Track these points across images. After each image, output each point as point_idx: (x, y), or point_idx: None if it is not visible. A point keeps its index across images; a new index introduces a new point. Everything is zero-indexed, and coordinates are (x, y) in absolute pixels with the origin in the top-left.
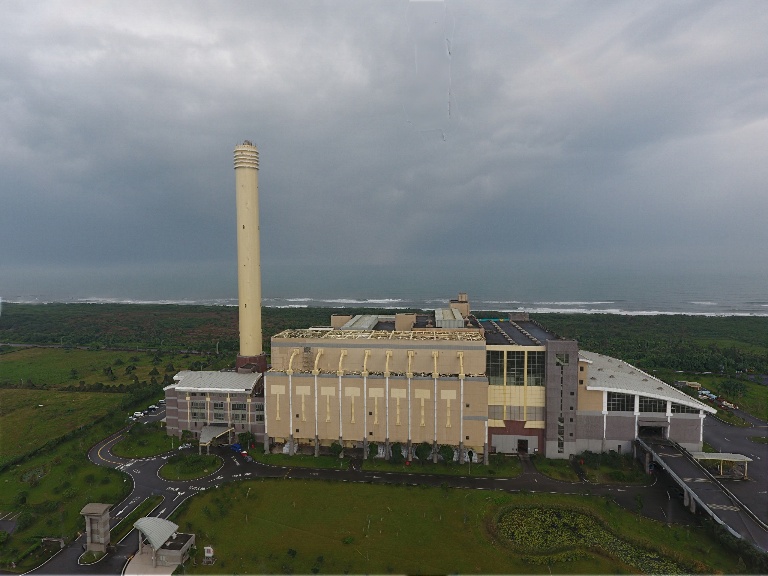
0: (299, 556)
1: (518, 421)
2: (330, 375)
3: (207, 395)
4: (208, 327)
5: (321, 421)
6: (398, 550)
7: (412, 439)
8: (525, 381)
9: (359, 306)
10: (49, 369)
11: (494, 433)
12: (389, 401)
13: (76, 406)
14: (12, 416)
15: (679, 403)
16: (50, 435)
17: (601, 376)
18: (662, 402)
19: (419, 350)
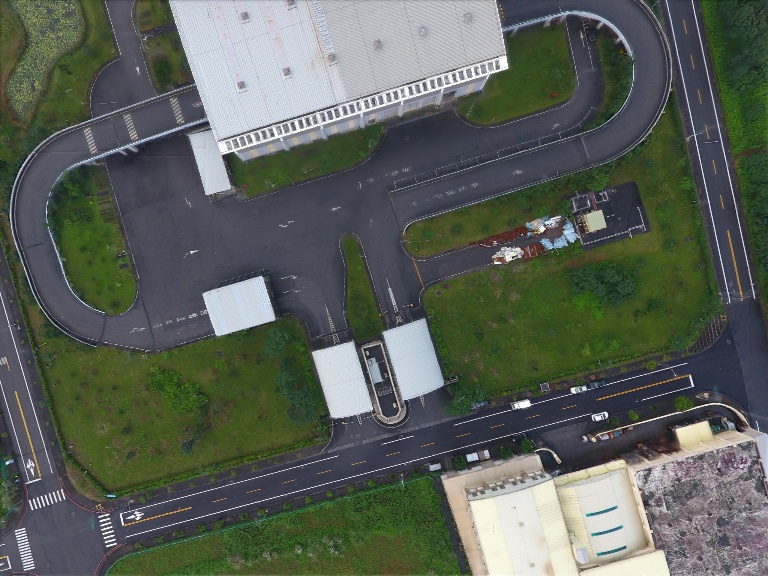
0: None
1: None
2: None
3: None
4: None
5: None
6: None
7: None
8: None
9: None
10: None
11: None
12: None
13: None
14: None
15: None
16: None
17: (245, 0)
18: None
19: None
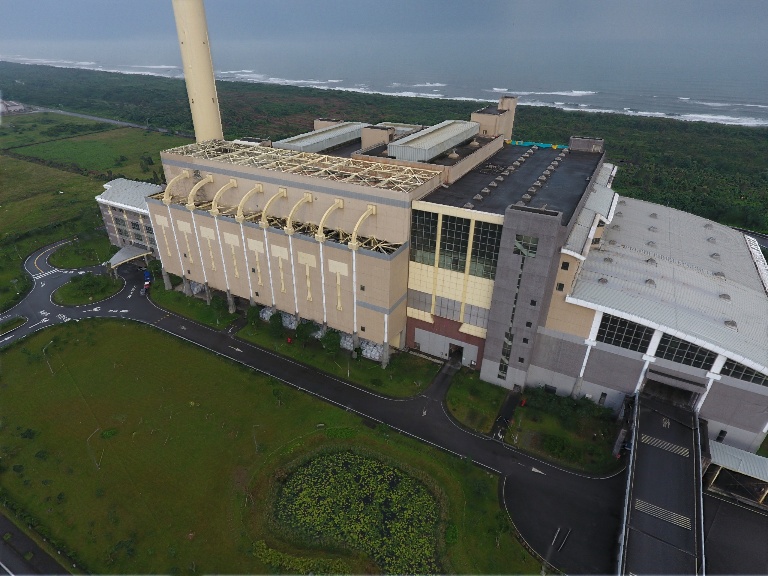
0: (45, 437)
1: (451, 320)
2: (206, 213)
3: (124, 212)
4: (302, 116)
5: (207, 267)
6: (141, 467)
7: (300, 312)
8: (466, 267)
9: (484, 99)
10: (111, 152)
11: (418, 327)
12: (270, 260)
13: (83, 198)
14: (29, 201)
15: (742, 363)
16: (29, 227)
17: (631, 276)
18: (707, 353)
19: (319, 194)
